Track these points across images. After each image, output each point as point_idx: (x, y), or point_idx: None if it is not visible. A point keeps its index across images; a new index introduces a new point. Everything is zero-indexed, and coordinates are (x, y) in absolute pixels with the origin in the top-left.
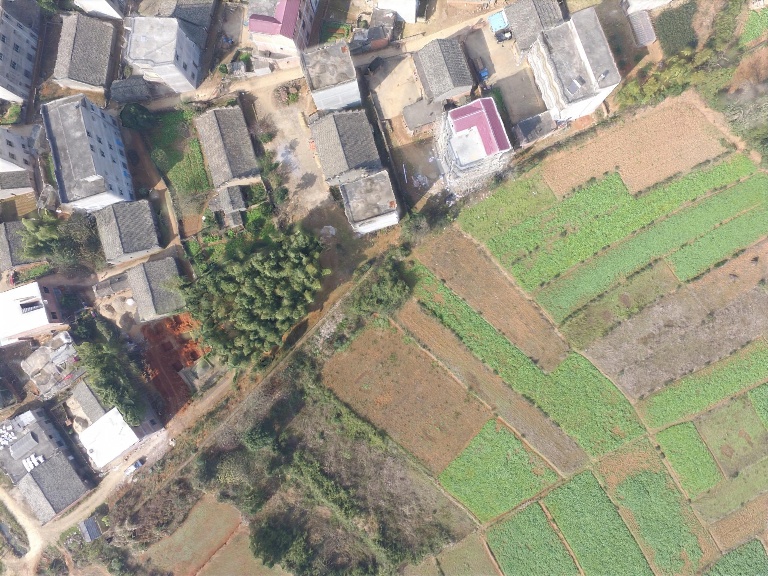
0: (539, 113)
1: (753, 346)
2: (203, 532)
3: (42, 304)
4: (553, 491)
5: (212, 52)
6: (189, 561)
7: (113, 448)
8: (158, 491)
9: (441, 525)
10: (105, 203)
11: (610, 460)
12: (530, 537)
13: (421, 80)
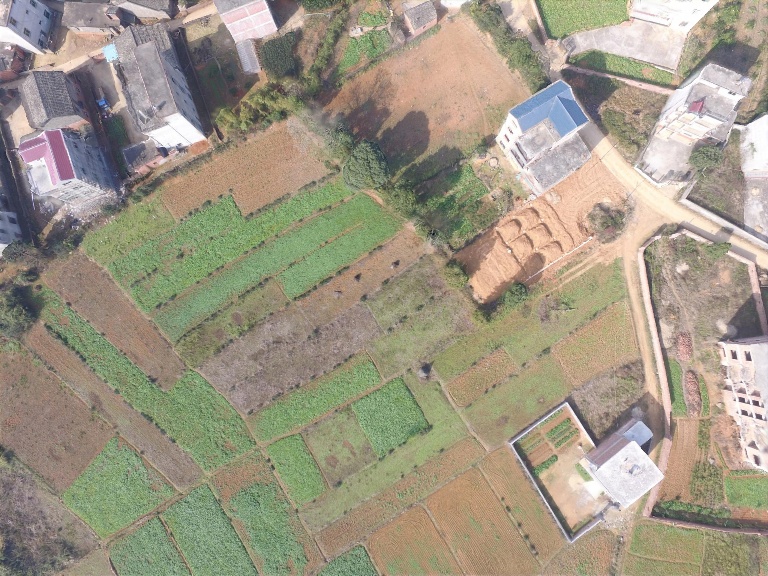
0: None
1: (356, 359)
2: None
3: None
4: (171, 505)
5: None
6: None
7: None
8: None
9: (66, 542)
10: None
11: (225, 473)
12: (150, 551)
13: (25, 111)
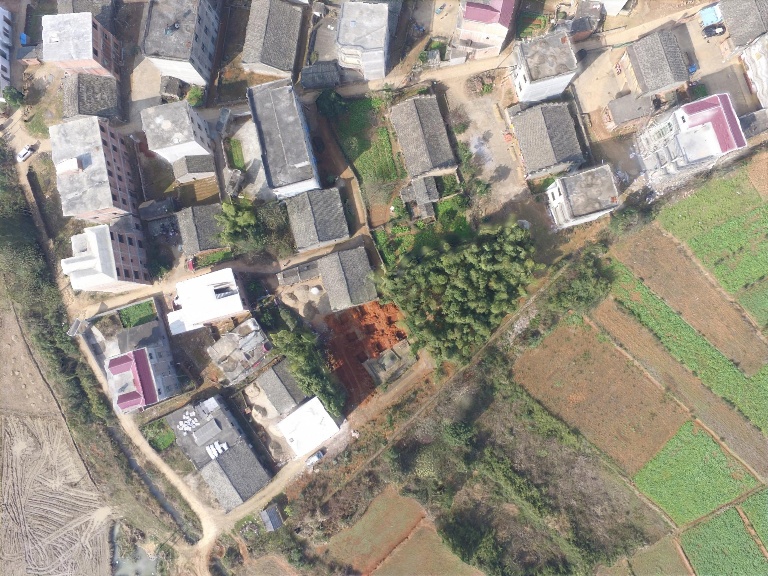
0: (753, 111)
1: None
2: (383, 525)
3: (233, 290)
4: (751, 496)
5: (403, 40)
6: (368, 554)
7: (314, 438)
8: (347, 483)
9: (634, 527)
10: (301, 190)
11: None
12: (726, 542)
13: (636, 74)
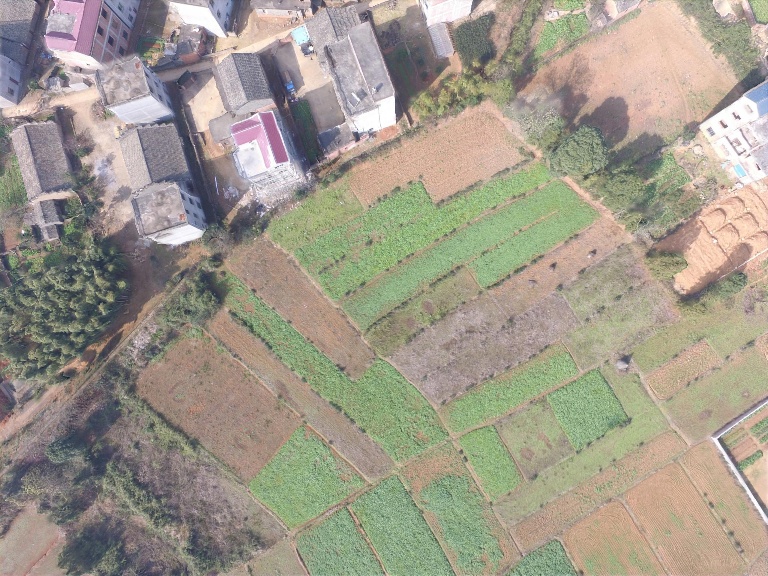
0: (338, 125)
1: (552, 350)
2: (25, 543)
3: None
4: (360, 496)
5: (32, 68)
6: (11, 573)
7: None
8: None
9: (252, 532)
10: None
11: (415, 465)
12: (338, 542)
13: (220, 94)
